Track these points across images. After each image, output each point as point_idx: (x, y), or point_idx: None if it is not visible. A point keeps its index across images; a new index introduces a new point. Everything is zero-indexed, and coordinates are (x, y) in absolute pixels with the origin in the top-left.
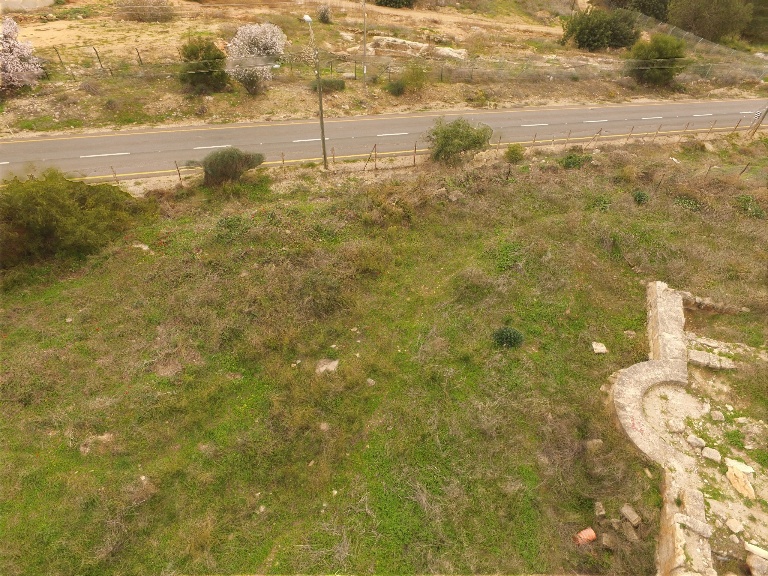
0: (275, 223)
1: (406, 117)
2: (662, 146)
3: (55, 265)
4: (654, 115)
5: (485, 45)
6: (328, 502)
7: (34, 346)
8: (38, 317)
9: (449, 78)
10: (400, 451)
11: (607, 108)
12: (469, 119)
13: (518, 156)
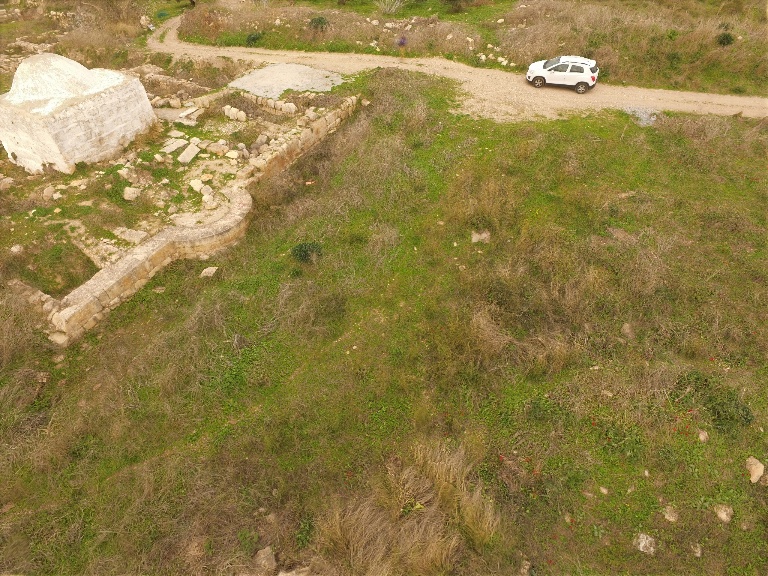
0: None
1: None
2: None
3: None
4: None
5: None
6: (461, 172)
7: (767, 250)
8: None
9: None
10: None
11: None
12: None
13: None
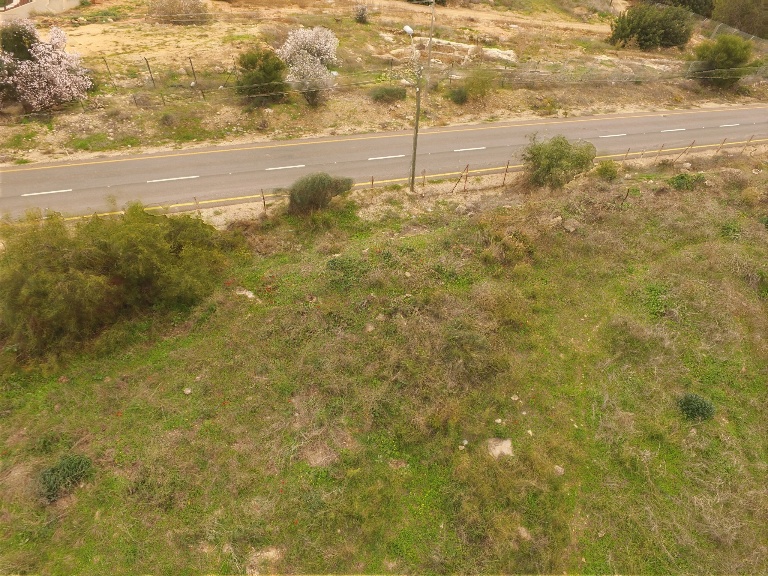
0: (392, 264)
1: (477, 129)
2: (750, 157)
3: (156, 320)
4: (730, 122)
5: (541, 47)
6: None
7: (157, 427)
8: (150, 387)
9: (510, 84)
10: (631, 570)
11: (679, 115)
12: (543, 130)
13: (613, 173)
